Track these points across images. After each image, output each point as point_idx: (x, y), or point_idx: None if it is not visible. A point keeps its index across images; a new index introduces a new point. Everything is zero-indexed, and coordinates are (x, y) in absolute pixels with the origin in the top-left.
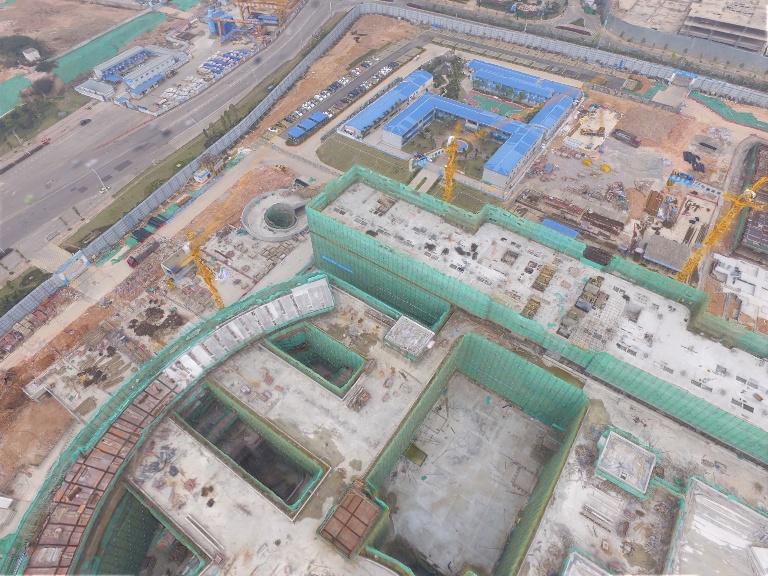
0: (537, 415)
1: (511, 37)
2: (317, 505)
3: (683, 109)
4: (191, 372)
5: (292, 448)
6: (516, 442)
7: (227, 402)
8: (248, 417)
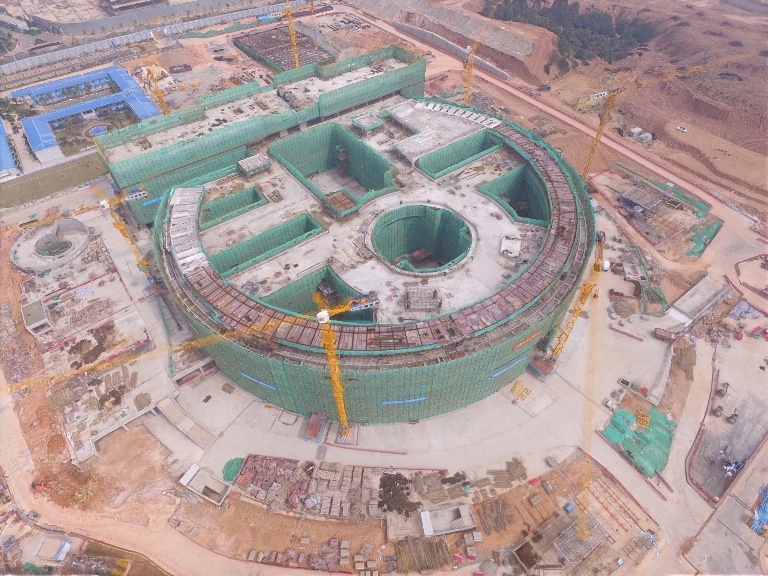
0: (325, 167)
1: (10, 69)
2: (325, 223)
3: (182, 44)
4: (197, 259)
5: (286, 226)
6: (333, 181)
7: (229, 261)
8: (250, 249)
